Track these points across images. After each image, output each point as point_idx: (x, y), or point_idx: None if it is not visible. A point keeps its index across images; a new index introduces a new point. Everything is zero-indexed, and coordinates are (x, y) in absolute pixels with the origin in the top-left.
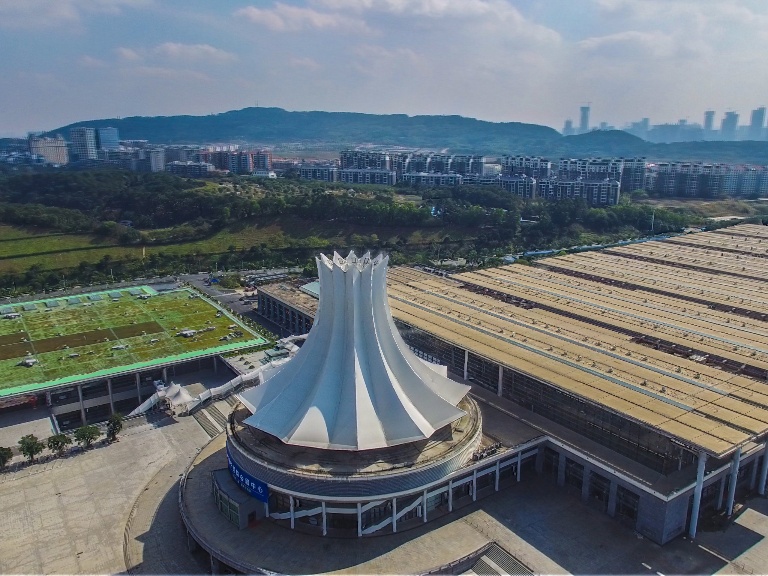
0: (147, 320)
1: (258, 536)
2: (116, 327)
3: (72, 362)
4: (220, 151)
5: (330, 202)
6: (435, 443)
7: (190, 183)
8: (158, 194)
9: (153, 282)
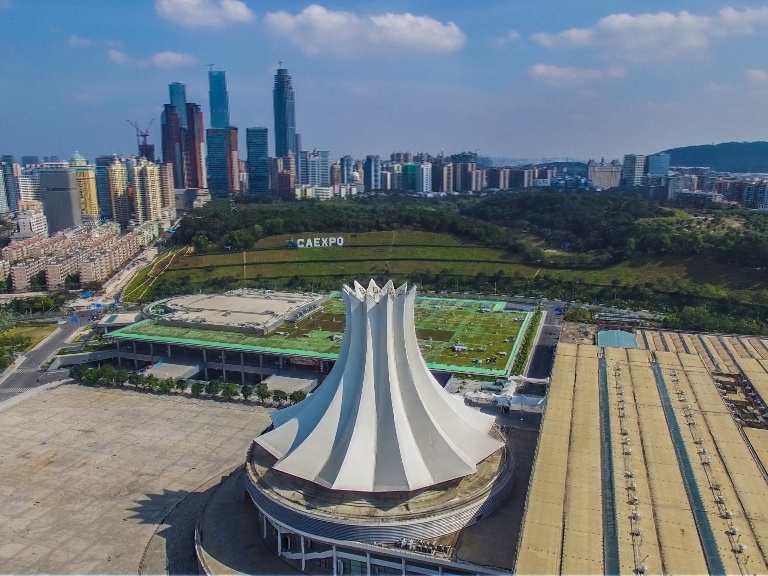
0: (451, 329)
1: (236, 510)
2: (423, 329)
3: None
4: (742, 180)
5: (757, 246)
6: (365, 504)
7: (656, 212)
8: (602, 220)
9: (518, 301)
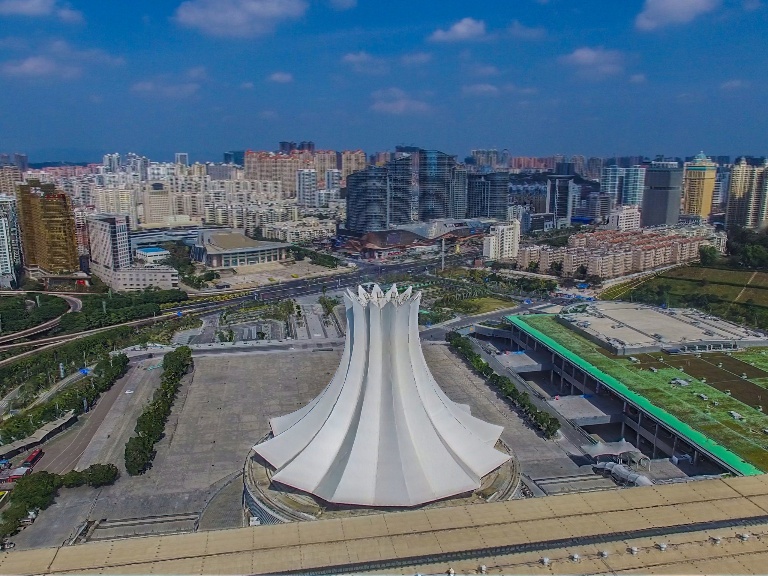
0: None
1: None
2: None
3: (684, 397)
4: None
5: None
6: None
7: None
8: None
9: None
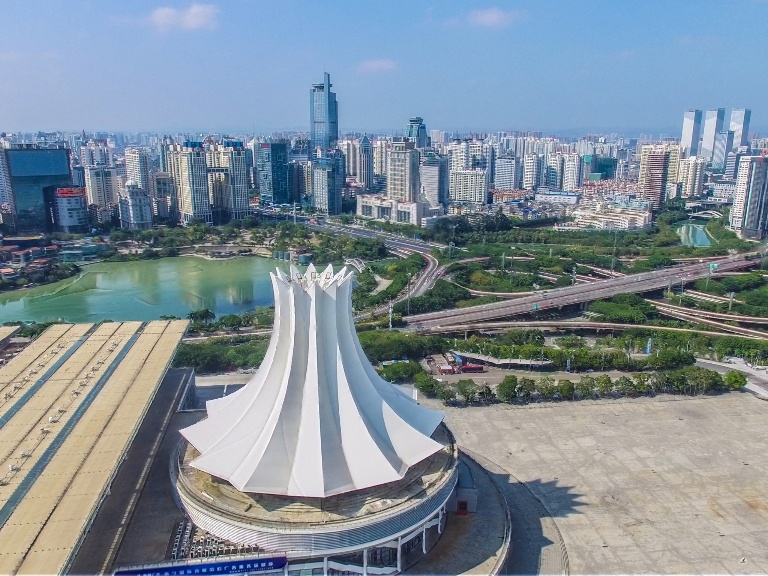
0: None
1: None
2: None
3: None
4: None
5: None
6: None
7: None
8: None
9: None
